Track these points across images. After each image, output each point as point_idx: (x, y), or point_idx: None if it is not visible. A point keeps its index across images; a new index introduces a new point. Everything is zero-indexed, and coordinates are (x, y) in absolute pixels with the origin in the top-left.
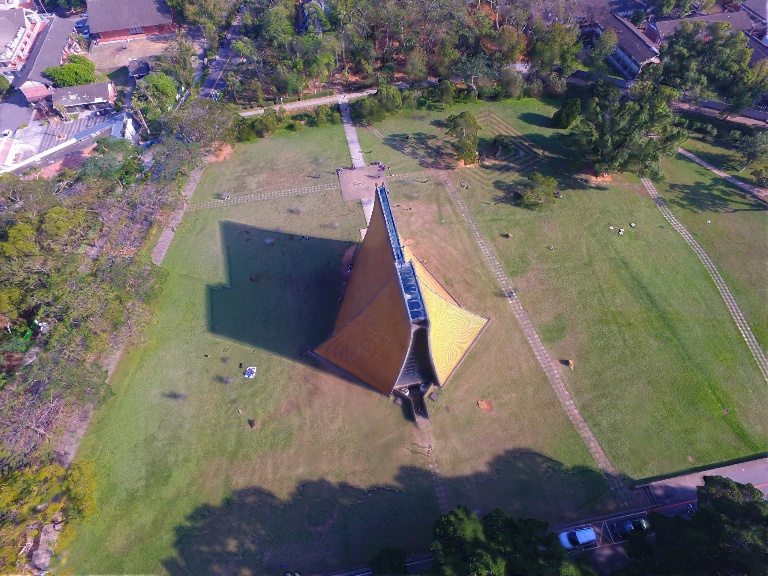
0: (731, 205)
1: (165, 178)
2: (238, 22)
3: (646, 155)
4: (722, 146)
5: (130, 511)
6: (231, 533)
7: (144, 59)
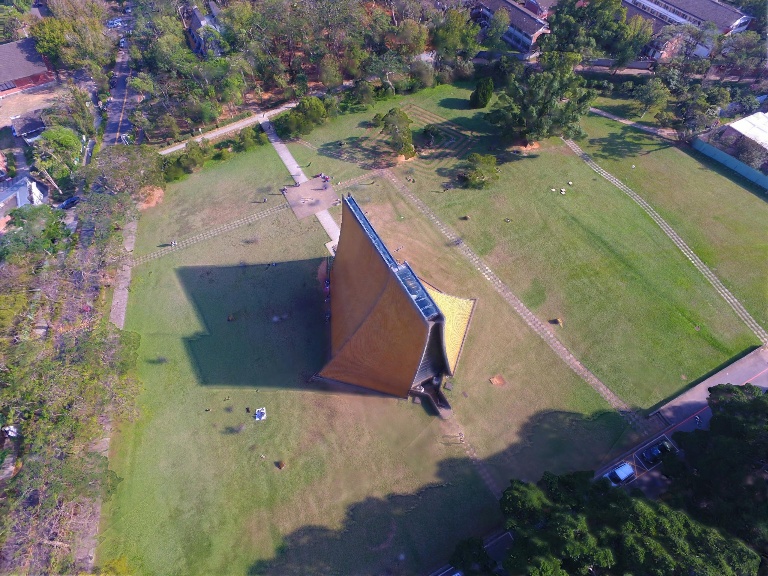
0: (644, 148)
1: (102, 237)
2: (122, 58)
3: (567, 118)
4: (620, 98)
5: None
6: None
7: (29, 115)
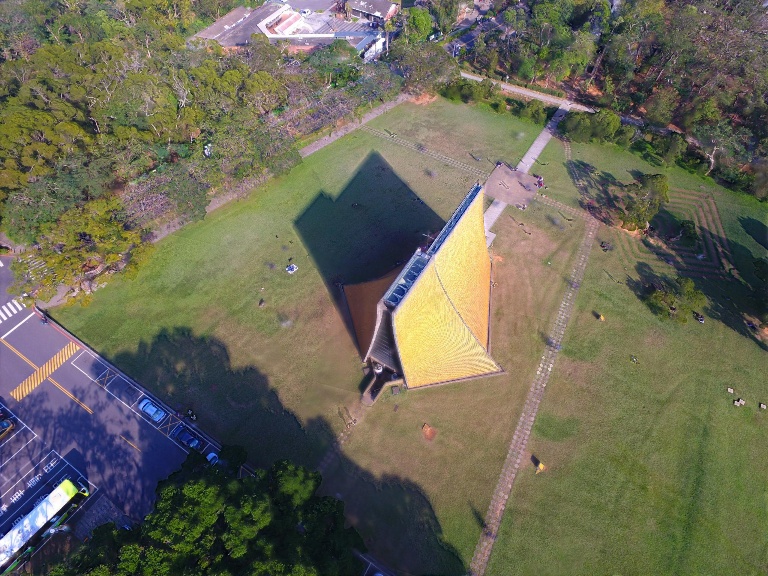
0: None
1: (357, 92)
2: None
3: None
4: None
5: (154, 296)
6: (187, 357)
7: None
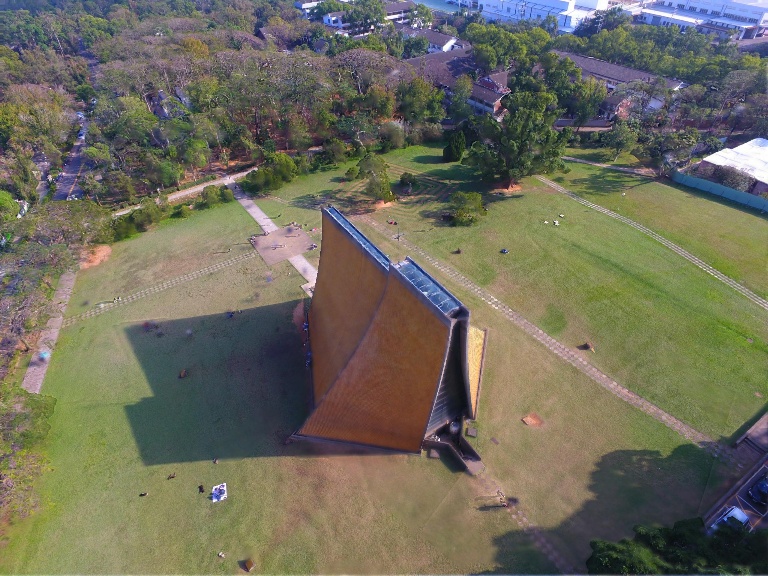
0: (626, 184)
1: (24, 289)
2: (81, 142)
3: (547, 153)
4: (589, 148)
5: None
6: None
7: None
